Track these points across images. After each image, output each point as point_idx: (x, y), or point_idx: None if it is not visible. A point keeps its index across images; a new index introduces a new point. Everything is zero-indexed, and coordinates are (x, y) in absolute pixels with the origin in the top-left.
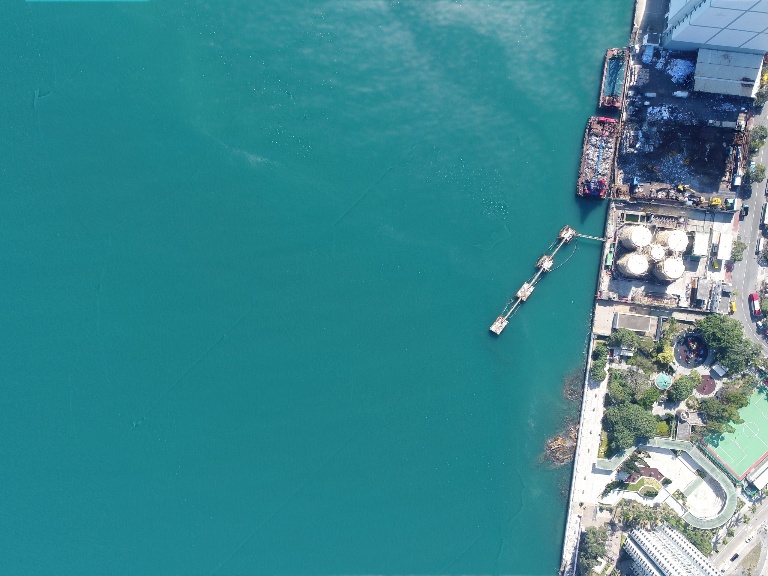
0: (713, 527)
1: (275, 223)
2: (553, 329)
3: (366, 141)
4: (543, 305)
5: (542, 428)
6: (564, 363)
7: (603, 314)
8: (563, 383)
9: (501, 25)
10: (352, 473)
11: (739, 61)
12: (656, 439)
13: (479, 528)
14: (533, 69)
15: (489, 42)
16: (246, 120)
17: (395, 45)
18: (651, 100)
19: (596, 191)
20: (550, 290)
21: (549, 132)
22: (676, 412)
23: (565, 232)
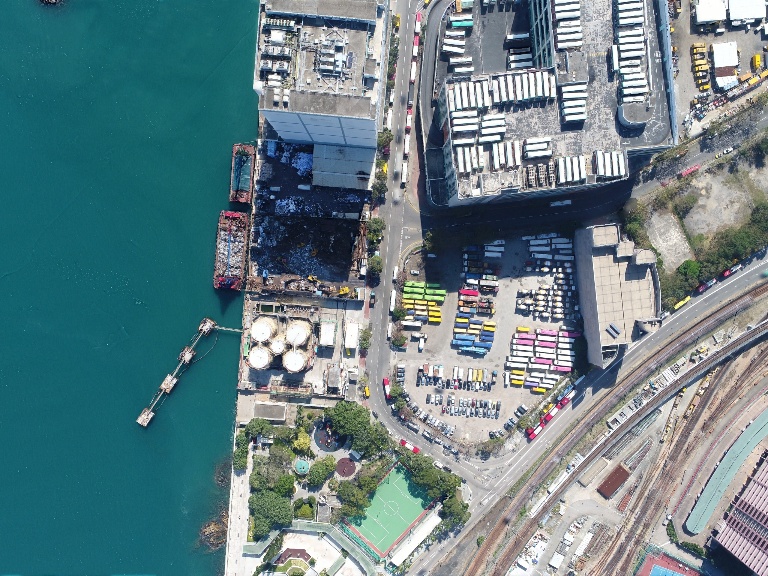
0: None
1: None
2: (201, 418)
3: None
4: (188, 396)
5: (197, 514)
6: (213, 451)
7: (245, 403)
8: (214, 470)
9: (133, 121)
10: None
11: (353, 155)
12: (298, 522)
13: None
14: (165, 164)
15: (123, 138)
16: None
17: (2, 152)
18: (279, 193)
19: (223, 286)
20: (194, 381)
21: (186, 226)
22: None
23: (202, 325)
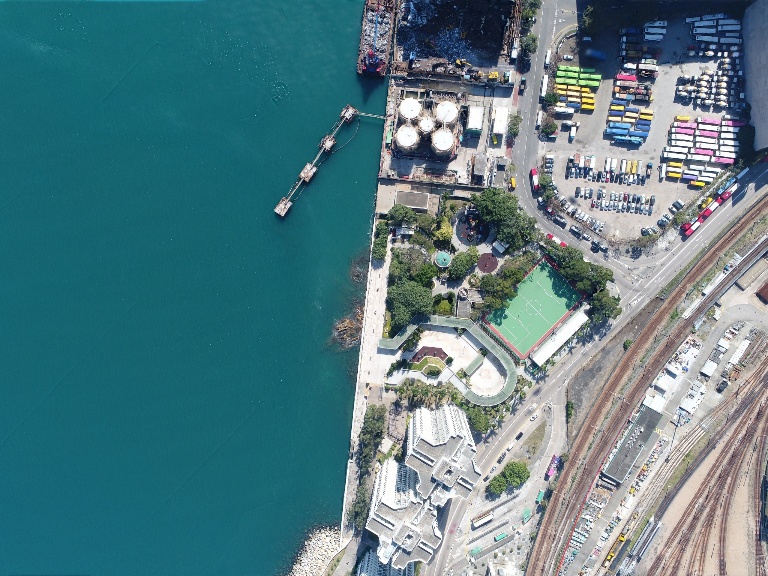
0: (494, 404)
1: (46, 101)
2: (338, 211)
3: (131, 15)
4: (327, 186)
5: (330, 311)
6: (350, 245)
7: (385, 193)
8: (350, 265)
9: None
10: (127, 350)
11: None
12: (437, 317)
13: (252, 403)
14: None
15: None
16: (30, 5)
17: None
18: None
19: (370, 66)
20: (334, 171)
21: (330, 11)
22: None
23: (345, 110)
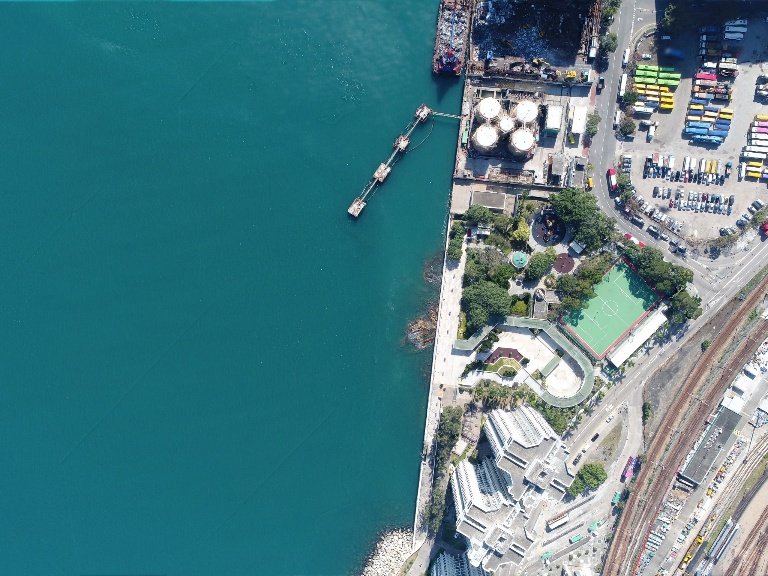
0: (571, 405)
1: (122, 101)
2: (412, 211)
3: (209, 15)
4: (401, 186)
5: (403, 312)
6: (423, 245)
7: (460, 193)
8: (423, 266)
9: None
10: (203, 351)
11: None
12: (513, 318)
13: (330, 404)
14: None
15: None
16: (101, 5)
17: None
18: None
19: (447, 65)
20: (408, 171)
21: (405, 10)
22: (534, 291)
23: (420, 110)
